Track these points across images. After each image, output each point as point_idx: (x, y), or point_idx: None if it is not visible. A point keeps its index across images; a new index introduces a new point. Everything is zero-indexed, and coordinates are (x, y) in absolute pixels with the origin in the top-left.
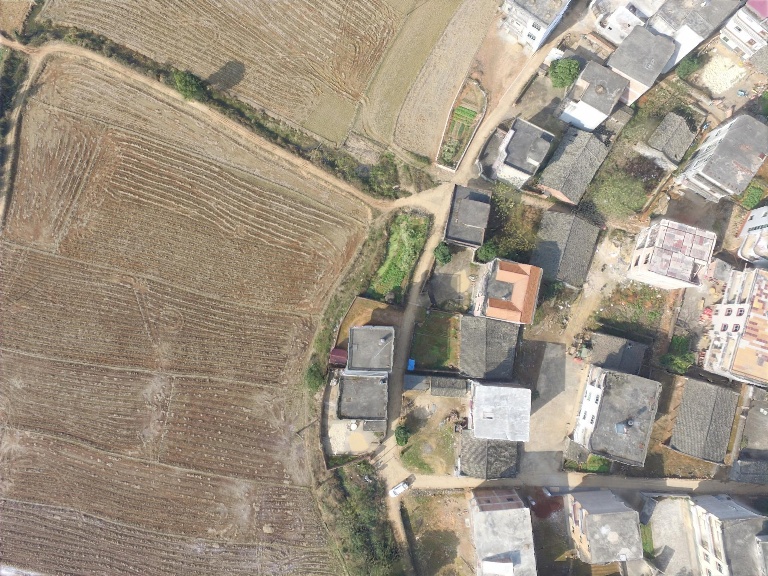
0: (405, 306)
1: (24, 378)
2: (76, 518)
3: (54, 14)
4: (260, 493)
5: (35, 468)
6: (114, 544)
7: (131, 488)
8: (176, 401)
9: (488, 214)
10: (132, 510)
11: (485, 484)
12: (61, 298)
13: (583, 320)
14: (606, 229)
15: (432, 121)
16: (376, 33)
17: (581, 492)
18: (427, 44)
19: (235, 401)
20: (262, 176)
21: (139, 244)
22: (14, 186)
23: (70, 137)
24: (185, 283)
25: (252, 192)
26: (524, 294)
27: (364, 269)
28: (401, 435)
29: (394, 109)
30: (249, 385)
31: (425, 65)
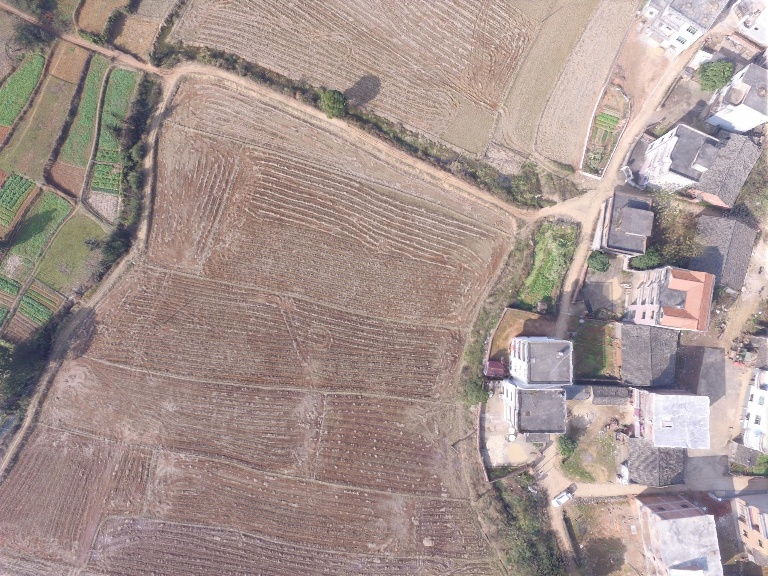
0: (557, 316)
1: (176, 401)
2: (236, 538)
3: (184, 35)
4: (418, 507)
5: (192, 490)
6: (275, 562)
7: (289, 506)
8: (329, 418)
9: (652, 222)
10: (291, 528)
11: (648, 491)
12: (208, 320)
13: (741, 324)
14: (760, 231)
15: (573, 128)
16: (511, 41)
17: (748, 495)
18: (564, 51)
19: (388, 416)
20: (403, 190)
21: (283, 263)
22: (154, 209)
23: (207, 158)
24: (331, 300)
25: (394, 207)
26: (700, 302)
27: (512, 280)
28: (569, 445)
29: (534, 118)
30: (401, 400)
31: (563, 72)
